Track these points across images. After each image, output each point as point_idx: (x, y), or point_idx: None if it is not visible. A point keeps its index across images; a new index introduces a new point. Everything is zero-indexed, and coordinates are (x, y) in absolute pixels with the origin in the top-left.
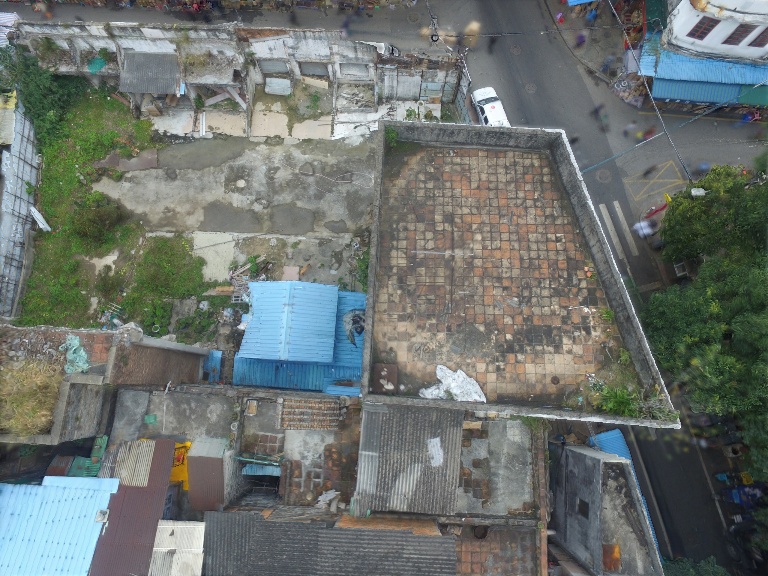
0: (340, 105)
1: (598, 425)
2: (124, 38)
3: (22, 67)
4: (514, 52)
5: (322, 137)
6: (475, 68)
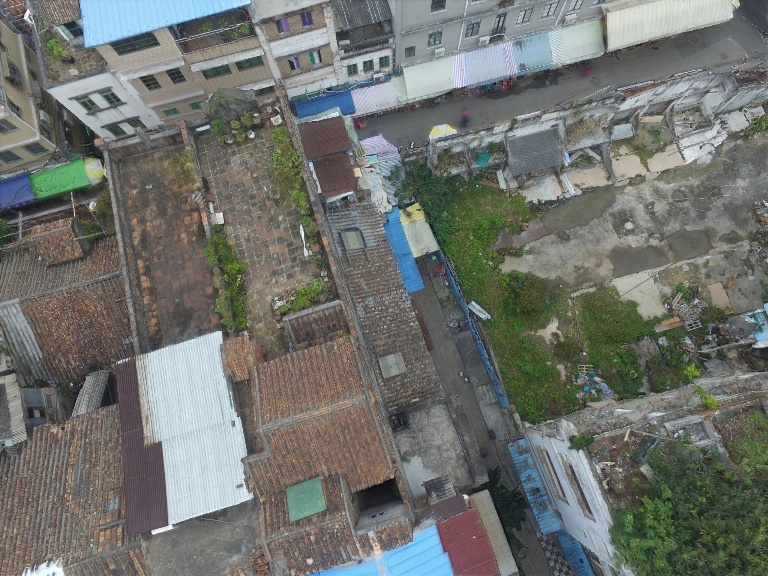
0: (678, 132)
1: None
2: (519, 128)
3: (422, 180)
4: None
5: (677, 164)
6: None
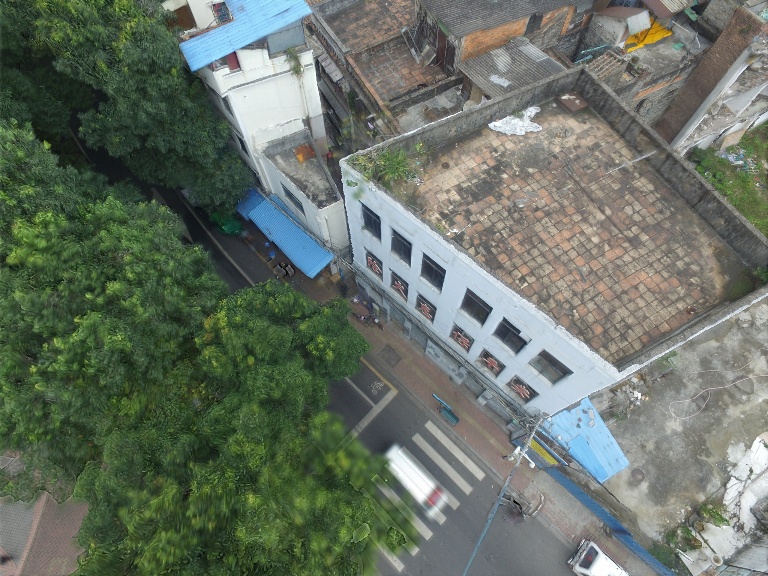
0: None
1: None
2: None
3: None
4: None
5: None
6: None
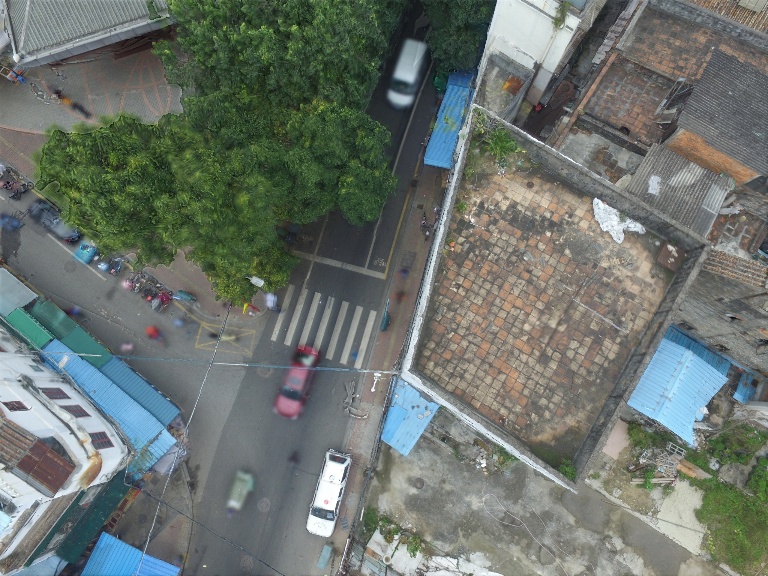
0: None
1: (416, 182)
2: None
3: None
4: (250, 561)
5: None
6: (303, 568)
